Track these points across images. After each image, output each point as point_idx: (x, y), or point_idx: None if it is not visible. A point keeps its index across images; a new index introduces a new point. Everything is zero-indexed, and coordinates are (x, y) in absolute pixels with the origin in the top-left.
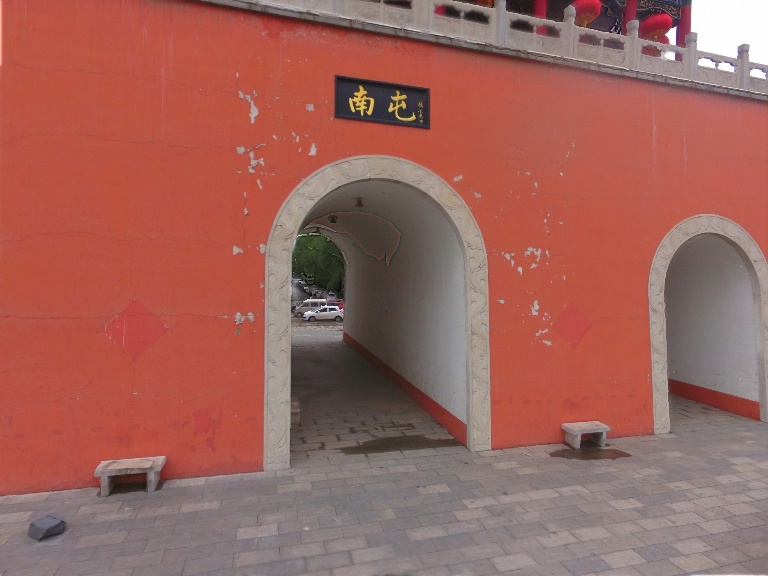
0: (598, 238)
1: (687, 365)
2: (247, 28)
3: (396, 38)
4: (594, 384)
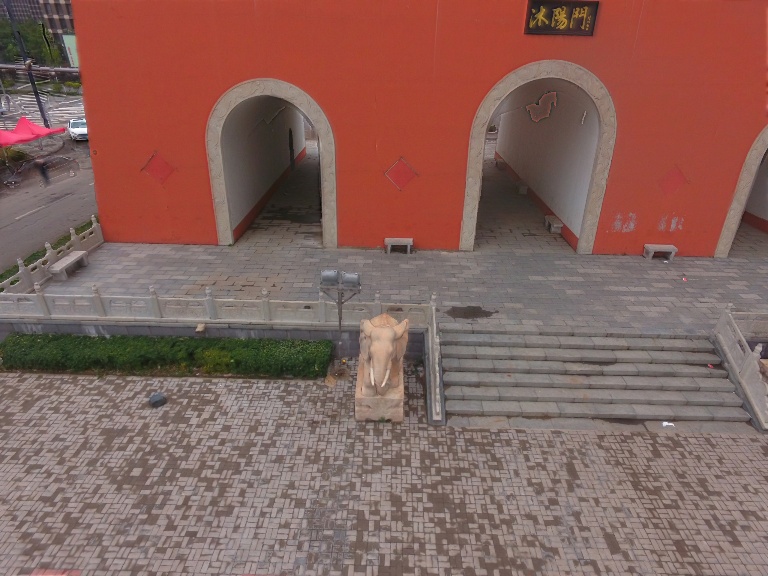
0: None
1: None
2: None
3: None
4: None
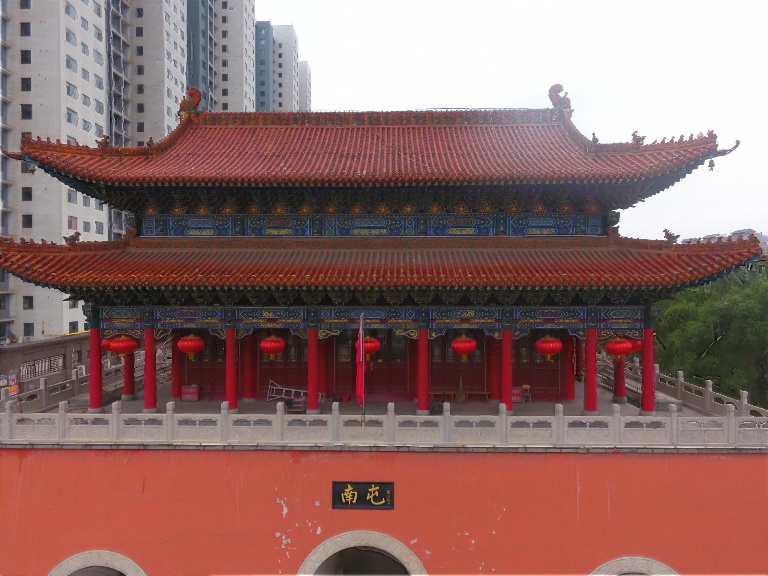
0: None
1: None
2: (282, 459)
3: (371, 451)
4: None
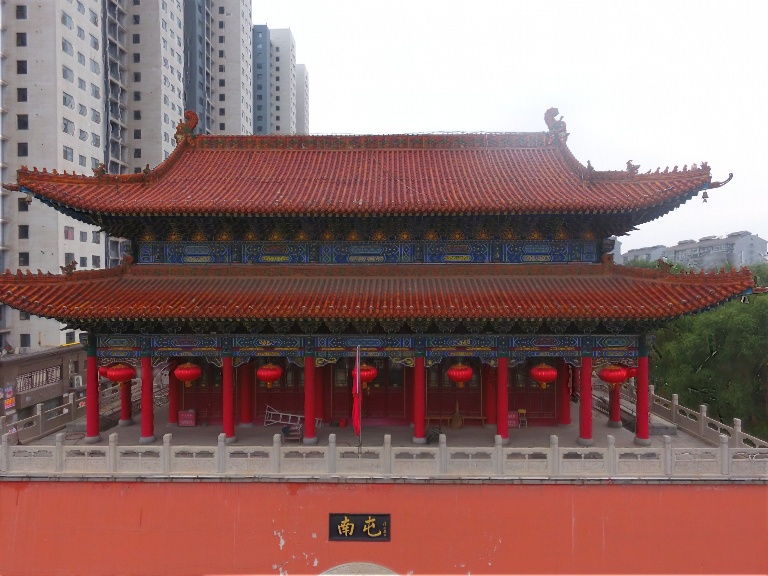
0: None
1: None
2: (279, 491)
3: (368, 483)
4: None
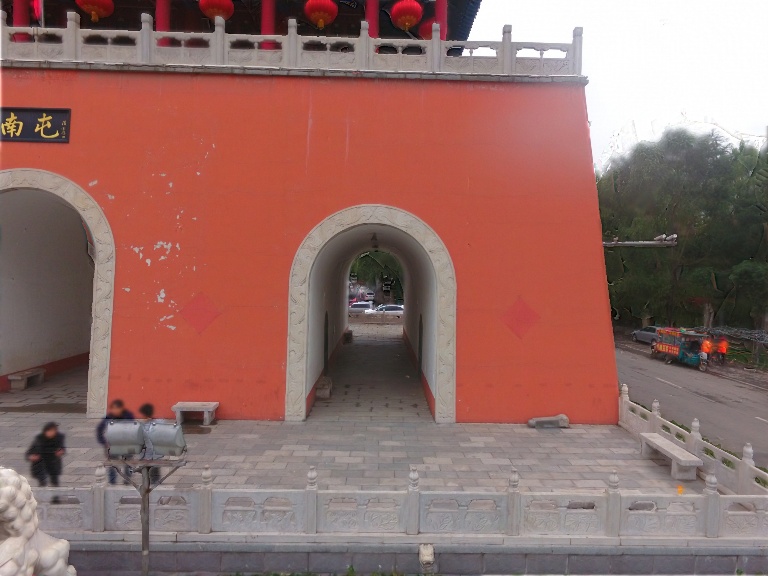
0: (236, 231)
1: (427, 361)
2: None
3: (42, 70)
4: (220, 368)
